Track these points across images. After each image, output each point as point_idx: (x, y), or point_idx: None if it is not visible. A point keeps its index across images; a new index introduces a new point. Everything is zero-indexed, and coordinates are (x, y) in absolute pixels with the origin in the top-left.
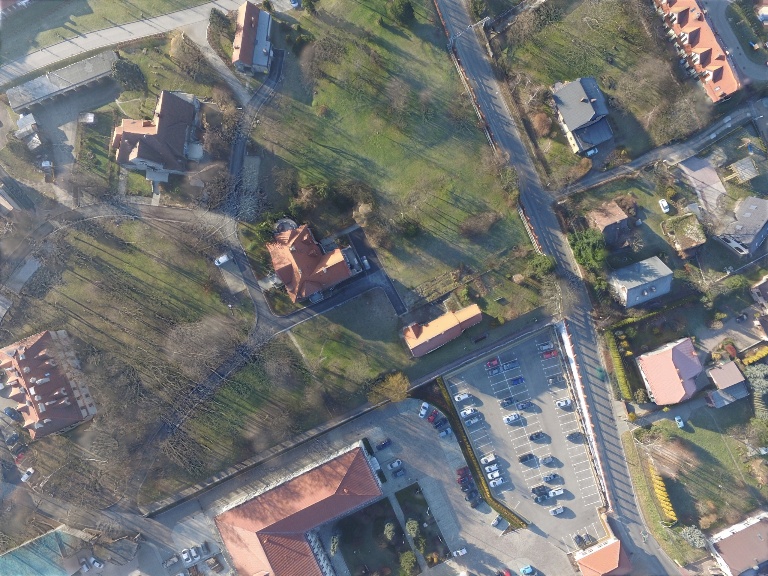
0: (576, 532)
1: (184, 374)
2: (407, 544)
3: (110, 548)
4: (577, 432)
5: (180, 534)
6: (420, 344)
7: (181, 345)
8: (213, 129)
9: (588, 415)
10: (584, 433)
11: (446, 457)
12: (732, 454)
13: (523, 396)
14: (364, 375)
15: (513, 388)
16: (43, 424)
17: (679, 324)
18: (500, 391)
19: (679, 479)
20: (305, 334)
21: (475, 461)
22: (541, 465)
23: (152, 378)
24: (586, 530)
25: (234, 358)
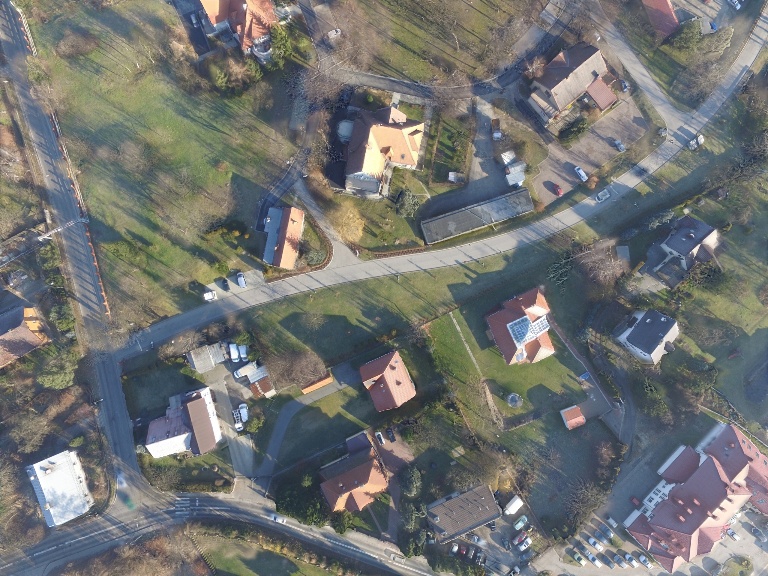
0: None
1: None
2: None
3: None
4: None
5: None
6: None
7: None
8: (333, 159)
9: None
10: None
11: None
12: None
13: None
14: None
15: None
16: None
17: None
18: None
19: None
20: None
21: None
22: None
23: None
24: None
25: None
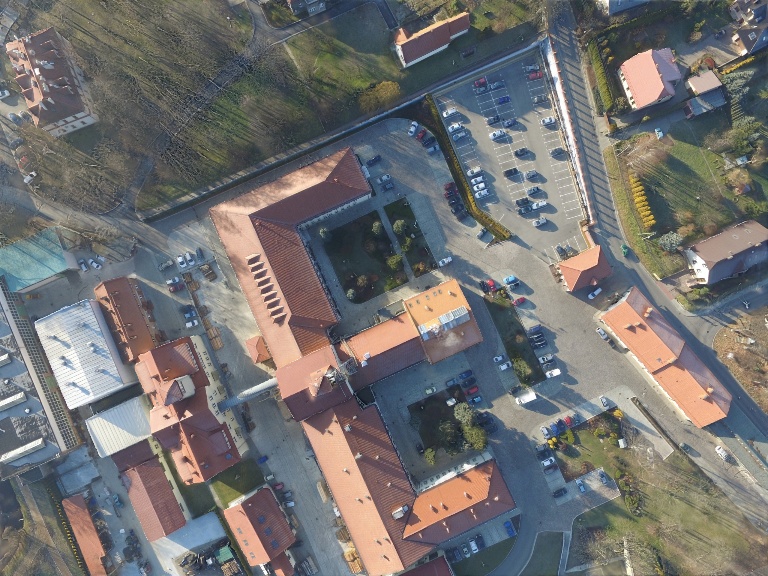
0: (558, 244)
1: (183, 84)
2: (395, 254)
3: (108, 245)
4: (560, 147)
5: (176, 241)
6: (410, 40)
7: (181, 56)
8: None
9: (571, 128)
10: (567, 150)
11: (434, 174)
12: (710, 167)
13: (509, 115)
14: (356, 85)
15: (499, 107)
16: (47, 107)
17: (660, 35)
18: (487, 110)
19: (658, 191)
20: (300, 45)
21: (461, 172)
22: (525, 180)
23: (152, 87)
24: (568, 242)
25: (231, 69)
